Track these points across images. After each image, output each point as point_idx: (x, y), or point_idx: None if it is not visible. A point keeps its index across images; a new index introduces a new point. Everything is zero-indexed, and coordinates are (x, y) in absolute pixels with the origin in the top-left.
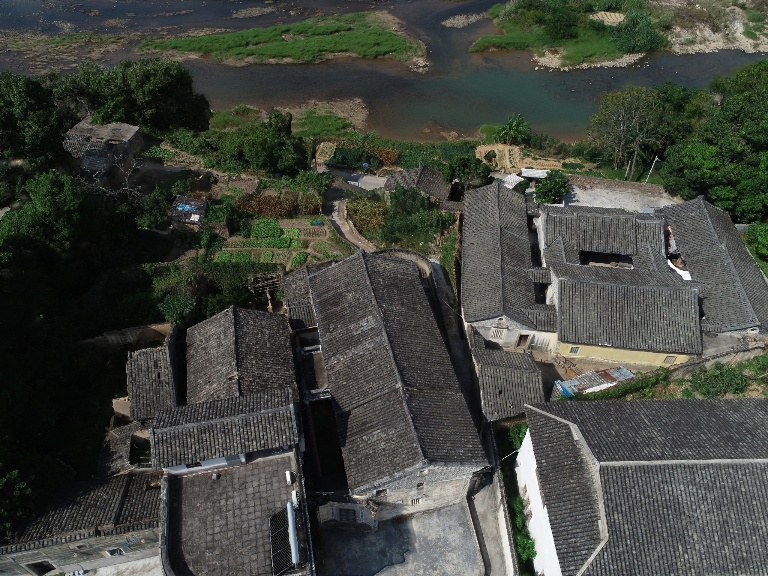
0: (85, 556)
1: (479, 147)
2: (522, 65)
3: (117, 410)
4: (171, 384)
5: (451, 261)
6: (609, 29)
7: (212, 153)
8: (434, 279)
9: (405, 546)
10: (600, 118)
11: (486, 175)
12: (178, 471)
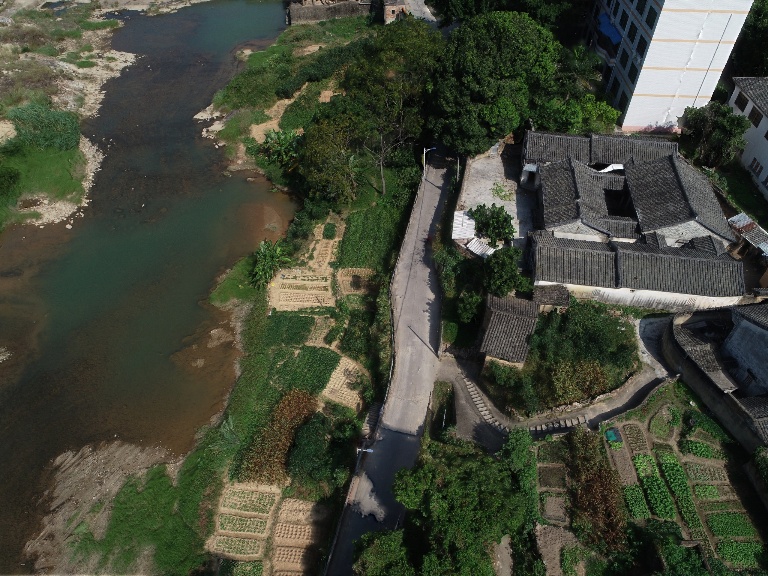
0: None
1: (273, 305)
2: (50, 238)
3: None
4: None
5: (637, 308)
6: (26, 141)
7: None
8: (708, 309)
9: None
10: None
11: None
12: None
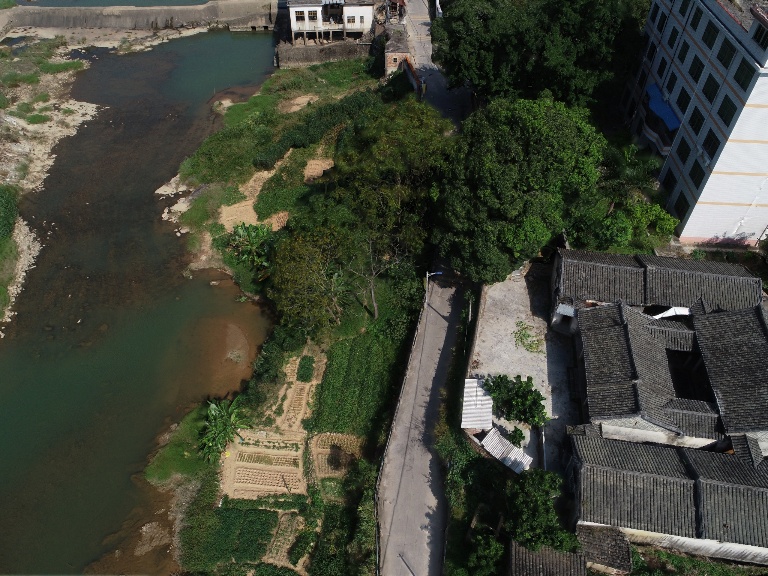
0: None
1: (224, 490)
2: None
3: None
4: None
5: (726, 568)
6: None
7: None
8: None
9: None
10: None
11: None
12: None
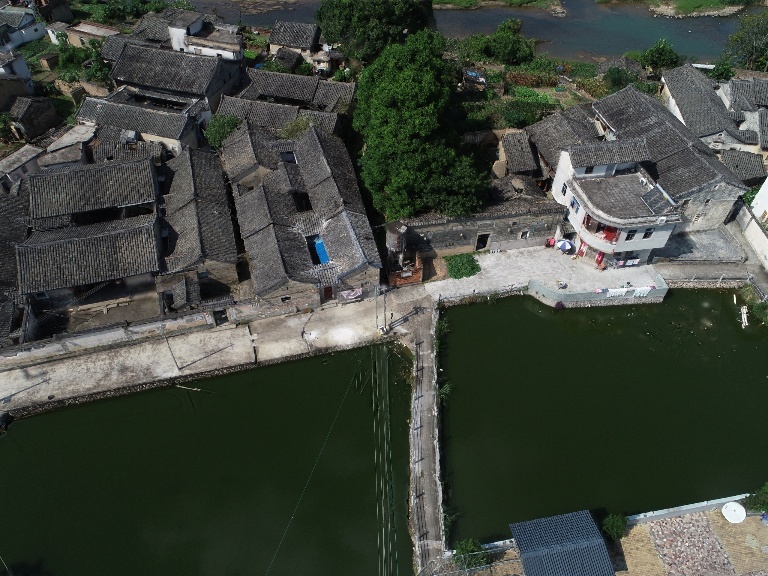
0: (509, 235)
1: None
2: (643, 13)
3: (494, 170)
4: (531, 153)
5: None
6: None
7: (459, 50)
8: None
9: (690, 246)
10: (740, 35)
11: (677, 60)
12: (579, 175)
